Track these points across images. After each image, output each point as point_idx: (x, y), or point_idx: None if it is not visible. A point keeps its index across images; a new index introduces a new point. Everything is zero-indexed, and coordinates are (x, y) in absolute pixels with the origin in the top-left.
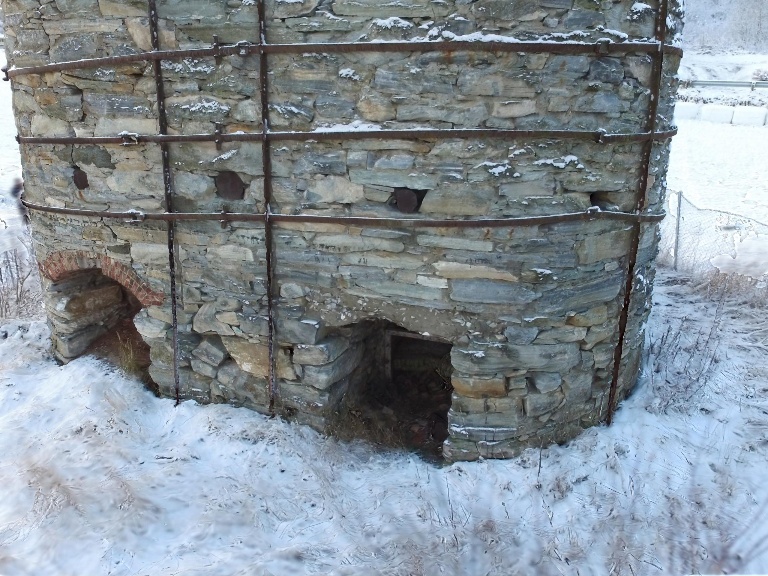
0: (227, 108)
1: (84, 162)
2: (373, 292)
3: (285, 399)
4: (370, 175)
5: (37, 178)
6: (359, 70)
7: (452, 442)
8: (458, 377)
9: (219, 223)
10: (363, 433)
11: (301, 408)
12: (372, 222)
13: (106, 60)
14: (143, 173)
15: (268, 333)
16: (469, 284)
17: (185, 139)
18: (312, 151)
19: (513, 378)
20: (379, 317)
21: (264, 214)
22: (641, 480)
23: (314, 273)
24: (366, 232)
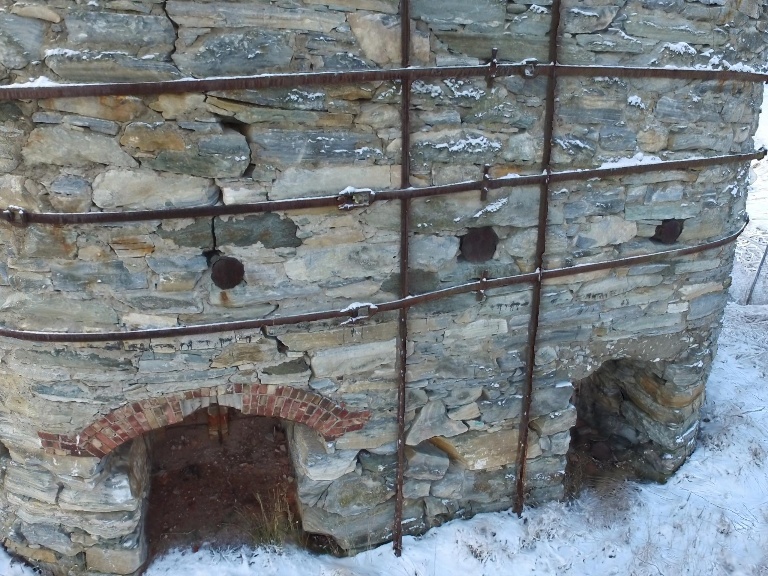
0: (499, 145)
1: (238, 243)
2: (626, 332)
3: (527, 482)
4: (646, 210)
5: (105, 285)
6: (643, 97)
7: (673, 454)
8: (682, 392)
9: (472, 295)
10: (584, 483)
11: (544, 484)
12: (644, 260)
13: (320, 77)
14: (356, 246)
15: (516, 413)
16: (699, 302)
17: (444, 191)
18: (593, 190)
19: (703, 377)
20: (619, 357)
21: (536, 273)
22: (766, 425)
23: (576, 328)
24: (634, 271)
